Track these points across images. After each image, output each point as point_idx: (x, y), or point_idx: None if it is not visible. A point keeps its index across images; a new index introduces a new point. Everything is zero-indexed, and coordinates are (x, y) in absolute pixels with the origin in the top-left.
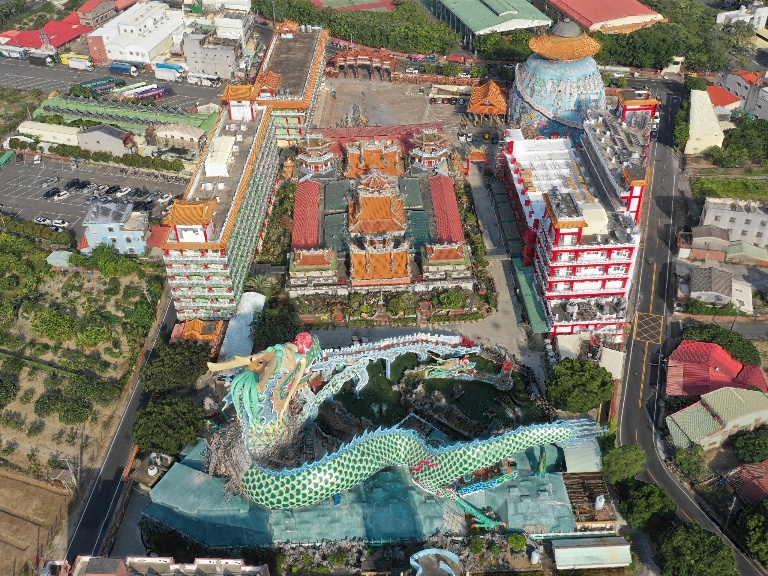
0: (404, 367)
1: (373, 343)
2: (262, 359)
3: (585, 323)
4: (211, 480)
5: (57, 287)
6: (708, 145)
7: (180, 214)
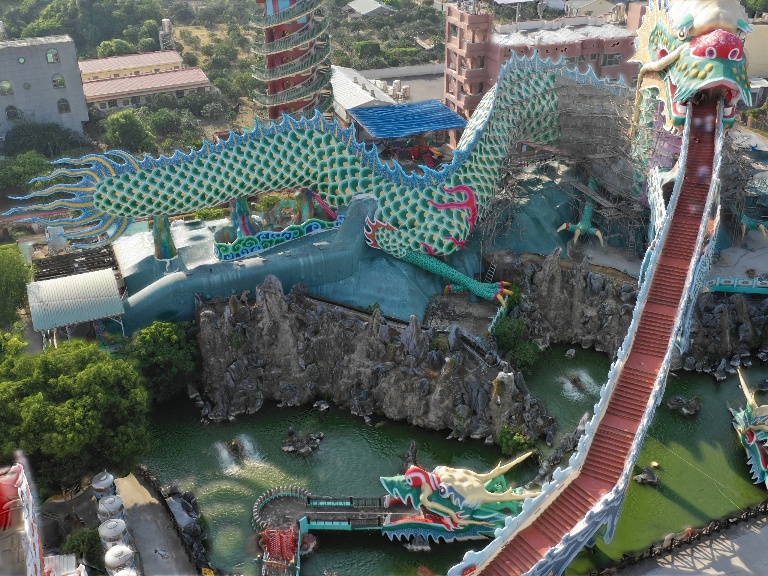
0: None
1: None
2: None
3: None
4: None
5: None
6: None
7: None
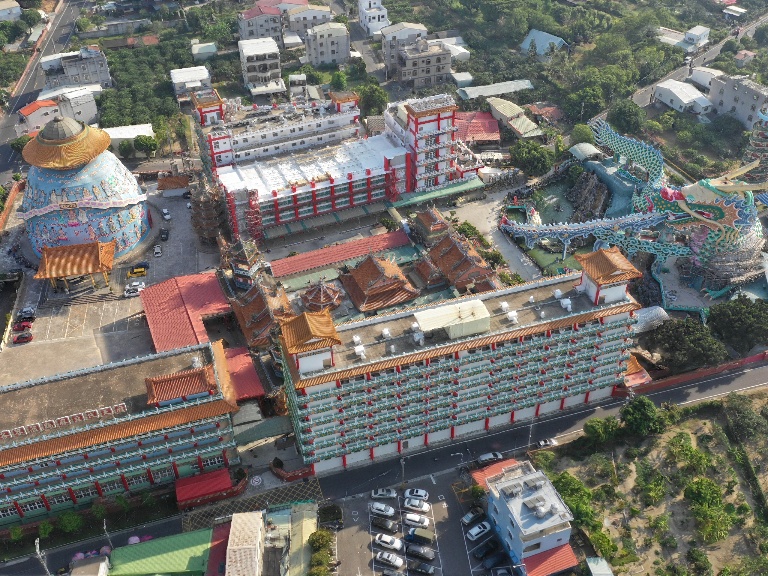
0: (546, 254)
1: (536, 271)
2: (723, 184)
3: (473, 155)
4: (767, 268)
5: (641, 568)
6: (153, 138)
7: (622, 267)
